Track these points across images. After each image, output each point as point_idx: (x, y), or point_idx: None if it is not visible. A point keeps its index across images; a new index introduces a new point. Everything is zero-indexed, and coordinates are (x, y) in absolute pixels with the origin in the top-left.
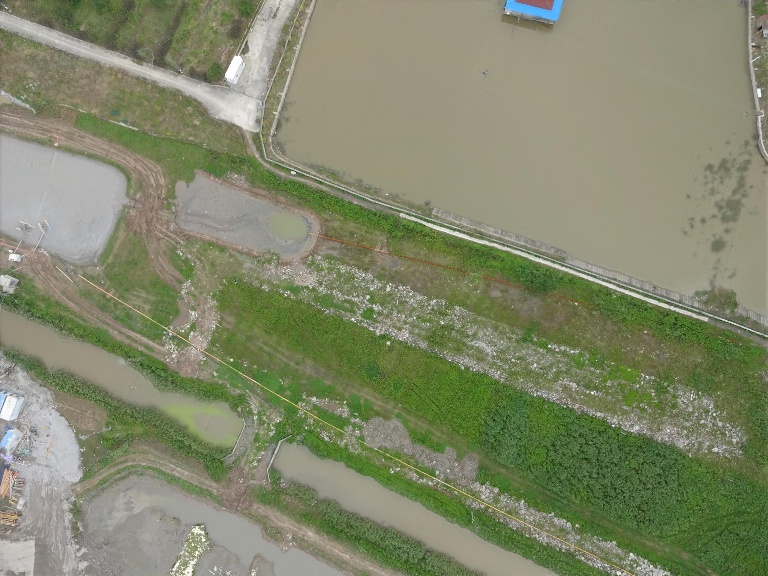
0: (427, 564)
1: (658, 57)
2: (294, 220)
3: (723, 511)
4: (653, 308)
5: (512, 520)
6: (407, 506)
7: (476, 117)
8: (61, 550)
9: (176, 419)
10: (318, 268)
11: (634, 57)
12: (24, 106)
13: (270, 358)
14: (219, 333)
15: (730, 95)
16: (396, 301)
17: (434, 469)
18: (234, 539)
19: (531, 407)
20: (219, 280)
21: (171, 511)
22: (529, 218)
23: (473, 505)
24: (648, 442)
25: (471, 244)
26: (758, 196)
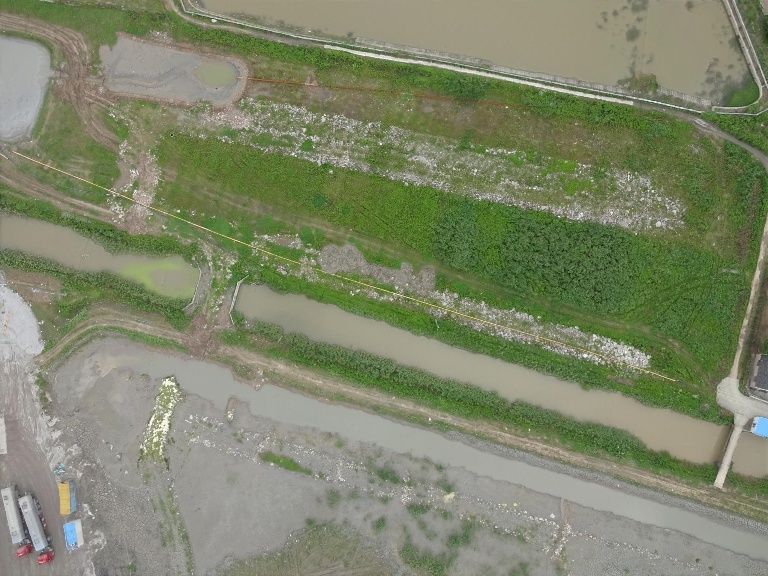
0: (399, 377)
1: None
2: (222, 68)
3: (674, 280)
4: (580, 99)
5: (476, 321)
6: (373, 328)
7: None
8: (32, 423)
9: (132, 279)
10: (252, 110)
11: None
12: None
13: (217, 203)
14: (163, 187)
15: None
16: (332, 130)
17: (393, 285)
18: (206, 386)
19: (478, 211)
20: (155, 136)
21: (139, 369)
22: (450, 36)
23: (436, 313)
24: (594, 225)
25: (397, 63)
26: None
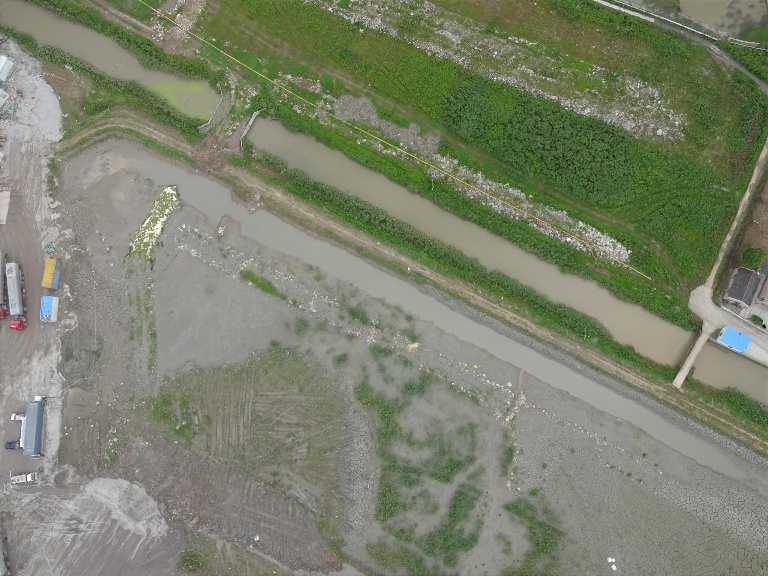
0: (388, 225)
1: None
2: None
3: (666, 185)
4: (605, 8)
5: (470, 188)
6: (372, 179)
7: None
8: (35, 201)
9: (157, 93)
10: None
11: None
12: None
13: (250, 39)
14: (204, 17)
15: None
16: None
17: (398, 141)
18: (204, 201)
19: (491, 89)
20: None
21: (145, 173)
22: None
23: (434, 174)
24: (598, 121)
25: None
26: None
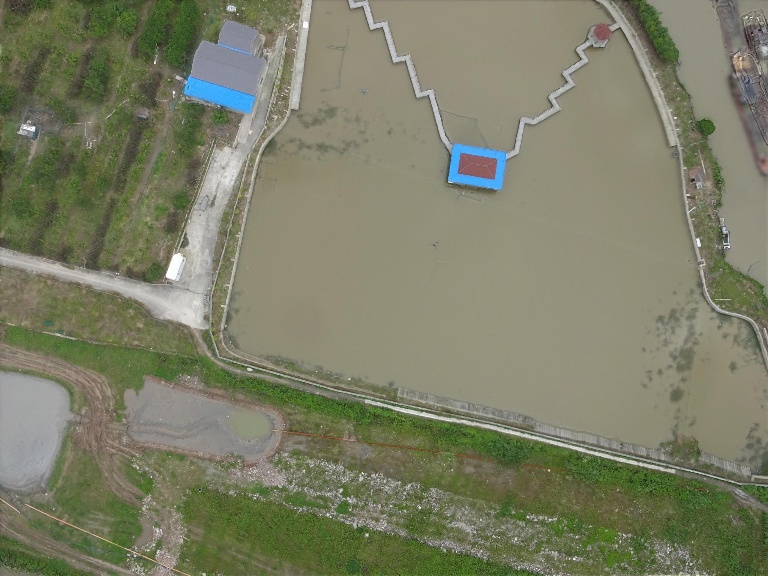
0: None
1: (602, 218)
2: (255, 417)
3: None
4: (623, 467)
5: None
6: None
7: (431, 292)
8: None
9: None
10: (286, 466)
11: (579, 220)
12: None
13: (245, 567)
14: (188, 547)
15: (672, 247)
16: (370, 491)
17: None
18: None
19: None
20: (182, 491)
21: None
22: (494, 386)
23: None
24: None
25: (440, 424)
26: (708, 342)
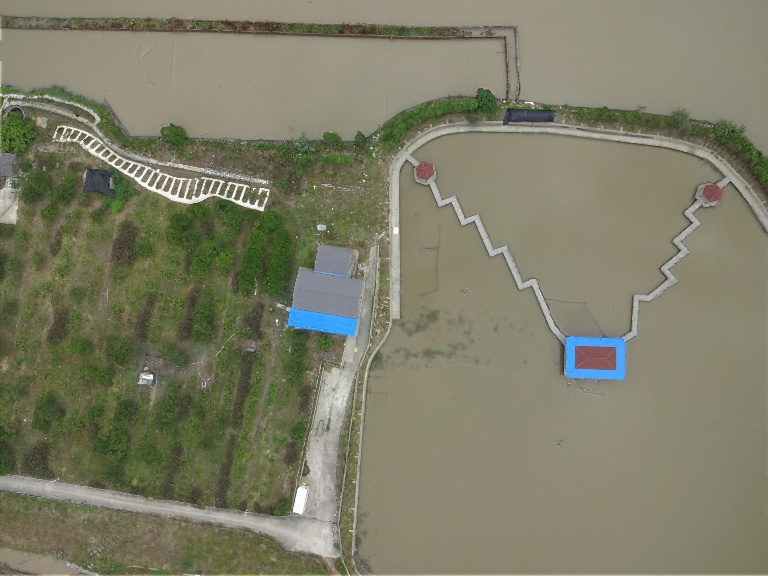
0: None
1: (741, 398)
2: None
3: None
4: None
5: None
6: None
7: (562, 495)
8: None
9: None
10: None
11: (715, 404)
12: (93, 574)
13: None
14: None
15: None
16: None
17: None
18: None
19: None
20: None
21: None
22: None
23: None
24: None
25: None
26: None
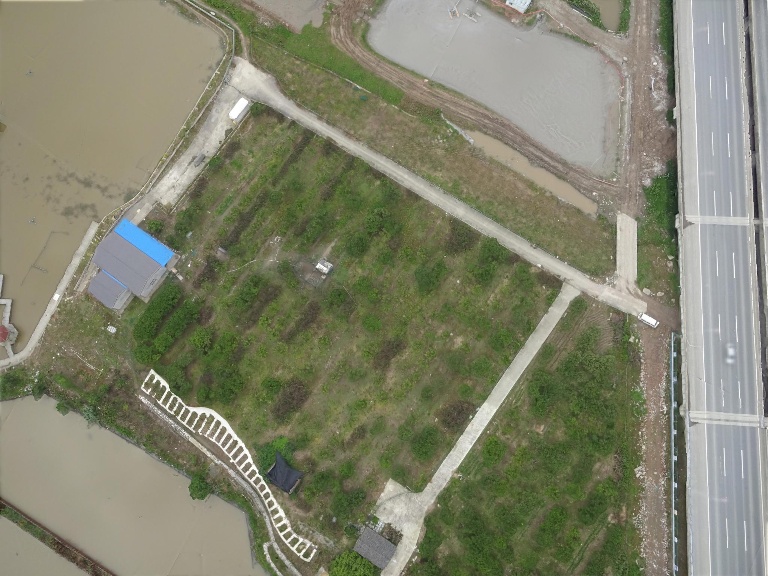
0: None
1: None
2: None
3: None
4: None
5: None
6: None
7: (48, 35)
8: None
9: None
10: None
11: None
12: (452, 124)
13: None
14: None
15: None
16: None
17: None
18: None
19: None
20: None
21: None
22: None
23: None
24: None
25: None
26: None
